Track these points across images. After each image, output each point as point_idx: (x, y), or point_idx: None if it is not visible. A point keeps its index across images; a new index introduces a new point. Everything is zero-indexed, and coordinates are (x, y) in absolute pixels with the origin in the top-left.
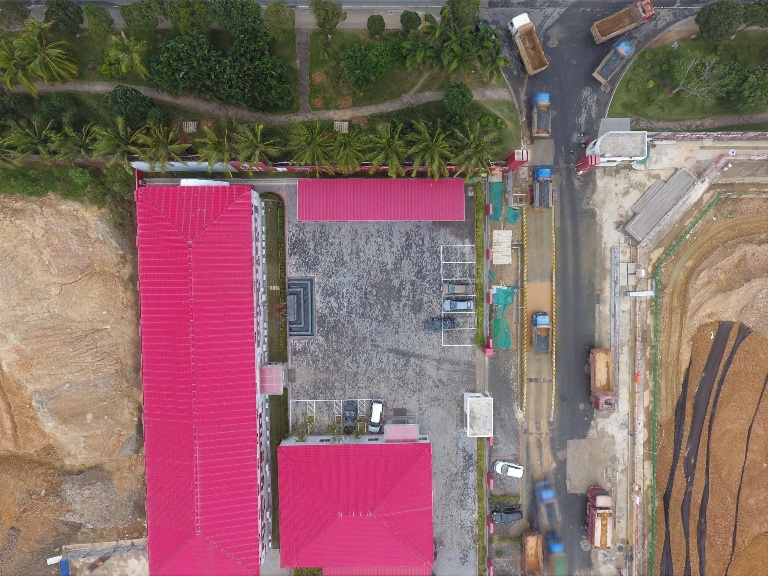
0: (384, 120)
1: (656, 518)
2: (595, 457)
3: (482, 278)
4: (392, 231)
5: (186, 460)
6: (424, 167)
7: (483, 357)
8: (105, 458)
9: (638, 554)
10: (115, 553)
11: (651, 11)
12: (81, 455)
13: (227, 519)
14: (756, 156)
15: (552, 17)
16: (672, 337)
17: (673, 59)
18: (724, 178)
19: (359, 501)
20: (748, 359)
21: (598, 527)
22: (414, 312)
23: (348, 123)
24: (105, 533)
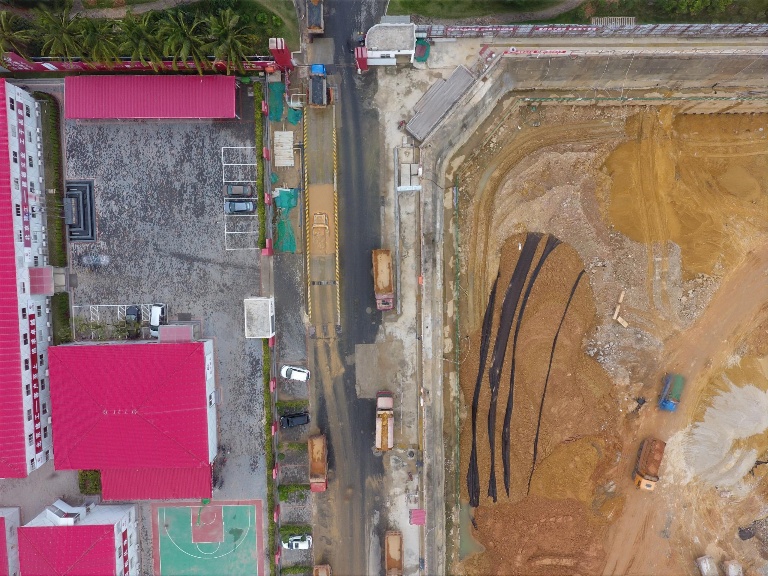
0: None
1: (464, 430)
2: (384, 362)
3: (265, 180)
4: (171, 133)
5: None
6: (191, 62)
7: (268, 261)
8: None
9: (428, 458)
10: None
11: None
12: None
13: None
14: (535, 53)
15: None
16: (477, 248)
17: None
18: (519, 82)
19: (126, 399)
20: (555, 270)
21: (379, 428)
22: (196, 215)
23: (122, 21)
24: None
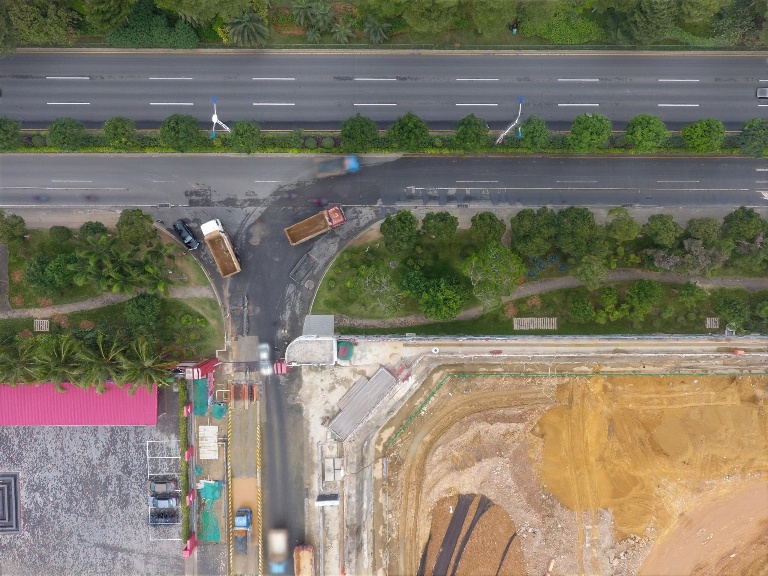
0: (85, 318)
1: None
2: None
3: (189, 472)
4: (97, 427)
5: None
6: None
7: (192, 551)
8: None
9: None
10: None
11: (339, 218)
12: None
13: None
14: None
15: (254, 215)
16: (408, 513)
17: (374, 258)
18: None
19: None
20: (486, 534)
21: None
22: (121, 507)
23: (49, 321)
24: None
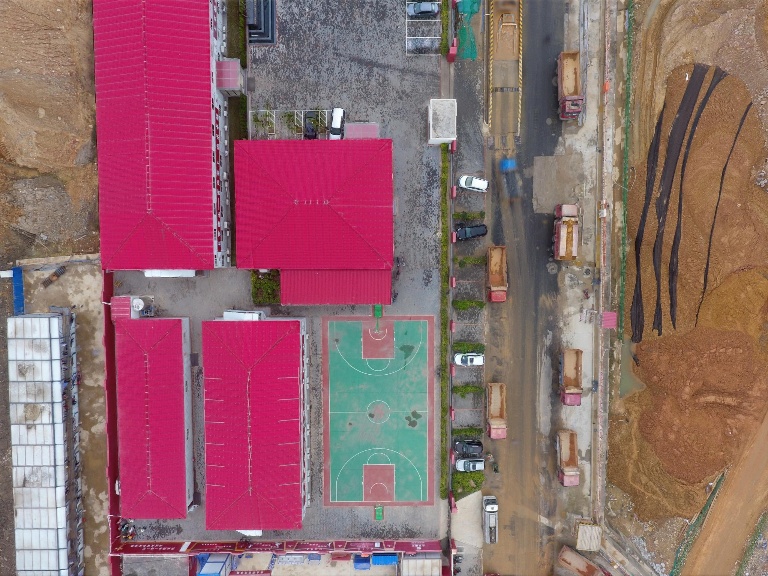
0: None
1: (627, 264)
2: (563, 175)
3: None
4: None
5: (137, 135)
6: None
7: (448, 68)
8: (59, 164)
9: (606, 276)
10: (70, 268)
11: None
12: (33, 153)
13: (180, 202)
14: None
15: None
16: (645, 76)
17: None
18: None
19: (316, 190)
20: (723, 101)
21: (563, 235)
22: (377, 19)
23: None
24: (60, 247)
